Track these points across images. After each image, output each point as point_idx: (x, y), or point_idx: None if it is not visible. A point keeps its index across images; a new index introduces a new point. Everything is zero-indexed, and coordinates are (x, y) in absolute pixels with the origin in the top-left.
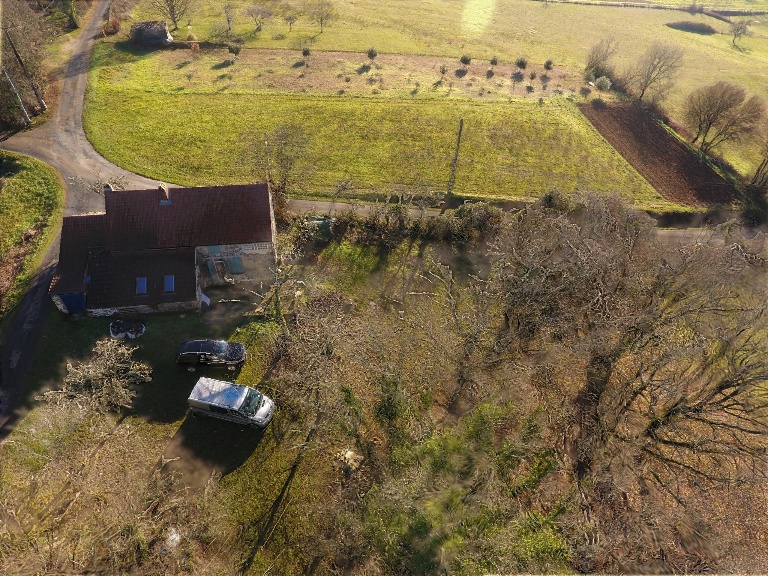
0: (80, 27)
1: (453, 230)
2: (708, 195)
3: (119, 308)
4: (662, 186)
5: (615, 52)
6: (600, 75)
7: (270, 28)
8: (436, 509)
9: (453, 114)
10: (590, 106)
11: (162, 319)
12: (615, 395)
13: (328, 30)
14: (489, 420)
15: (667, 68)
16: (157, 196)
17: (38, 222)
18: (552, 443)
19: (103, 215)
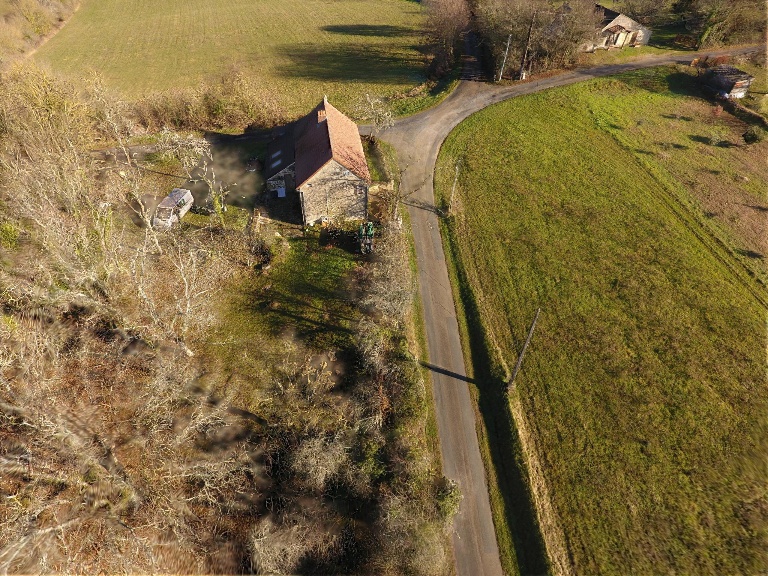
0: (699, 51)
1: (359, 344)
2: None
3: None
4: None
5: None
6: None
7: None
8: None
9: None
10: None
11: (261, 177)
12: None
13: None
14: None
15: None
16: None
17: None
18: None
19: None
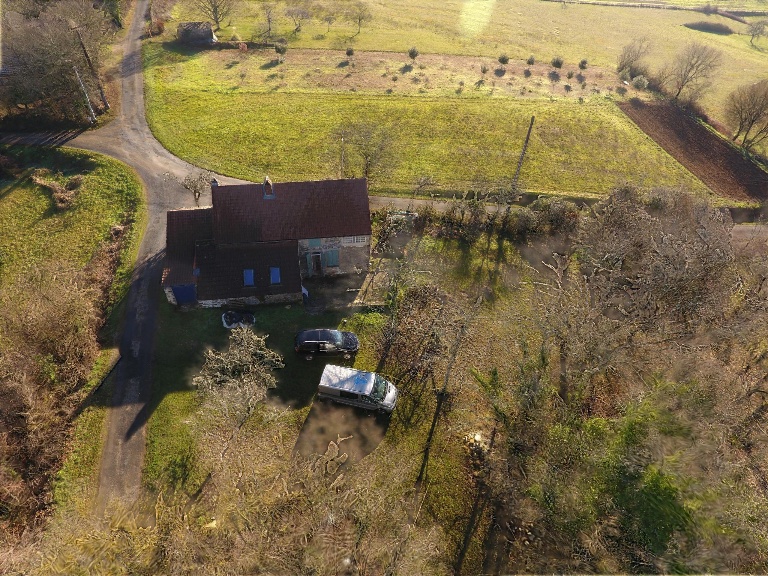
0: (125, 28)
1: (532, 224)
2: (757, 191)
3: (228, 299)
4: (712, 182)
5: (647, 52)
6: (633, 74)
7: (308, 28)
8: (690, 470)
9: (500, 112)
10: (629, 105)
11: (269, 310)
12: None
13: (364, 30)
14: (693, 393)
15: (705, 67)
16: (261, 190)
17: (124, 218)
18: (751, 414)
19: (205, 209)
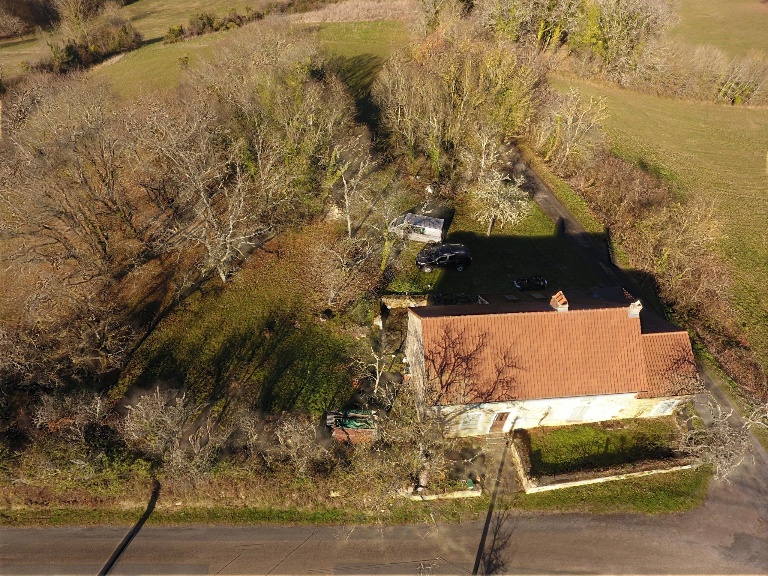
0: None
1: None
2: None
3: None
4: None
5: None
6: None
7: None
8: None
9: None
10: None
11: None
12: (116, 266)
13: None
14: None
15: None
16: None
17: None
18: None
19: None
